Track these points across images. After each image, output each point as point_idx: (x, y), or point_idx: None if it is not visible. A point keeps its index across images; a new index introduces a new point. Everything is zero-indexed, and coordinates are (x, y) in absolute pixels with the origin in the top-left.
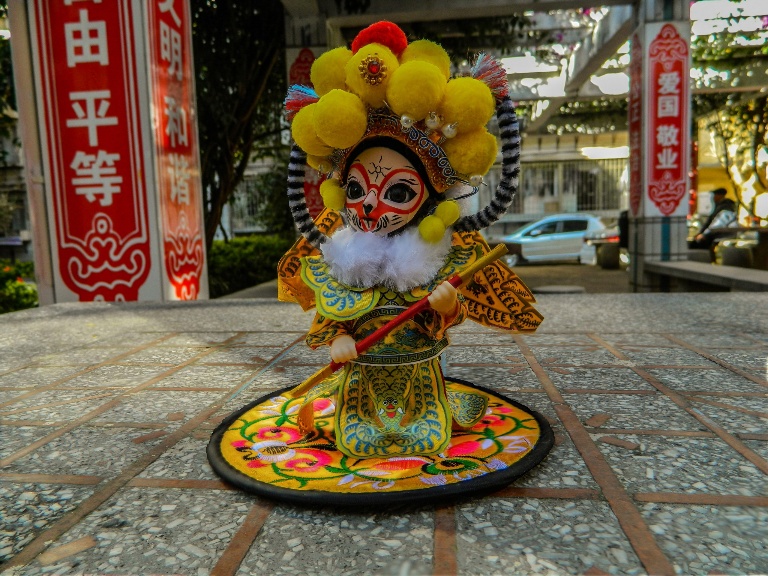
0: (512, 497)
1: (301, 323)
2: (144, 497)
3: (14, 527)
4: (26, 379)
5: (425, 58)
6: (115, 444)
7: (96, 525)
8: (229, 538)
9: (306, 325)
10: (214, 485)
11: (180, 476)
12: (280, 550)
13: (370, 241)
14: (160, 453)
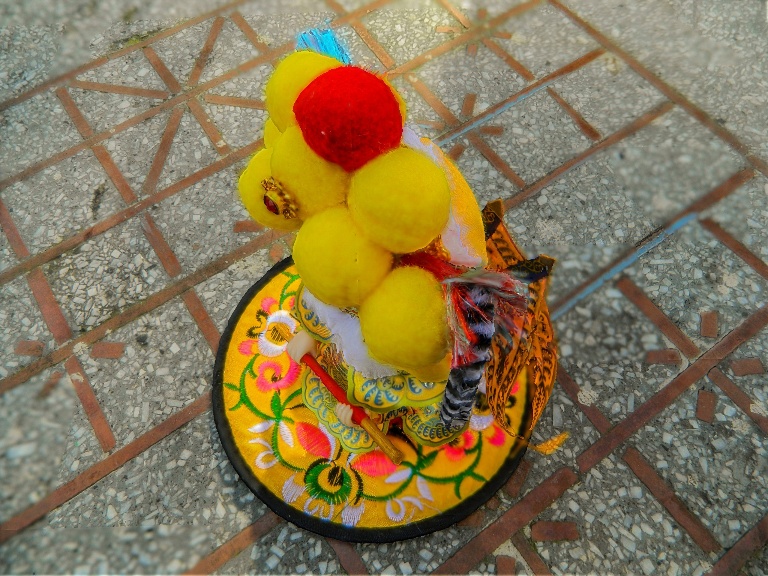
0: (330, 546)
1: (638, 0)
2: (176, 321)
3: (112, 294)
4: (276, 19)
5: (364, 224)
6: (223, 221)
7: (135, 334)
8: (166, 417)
9: (633, 14)
10: (214, 344)
11: (213, 310)
12: (173, 455)
13: (324, 306)
14: (232, 262)
